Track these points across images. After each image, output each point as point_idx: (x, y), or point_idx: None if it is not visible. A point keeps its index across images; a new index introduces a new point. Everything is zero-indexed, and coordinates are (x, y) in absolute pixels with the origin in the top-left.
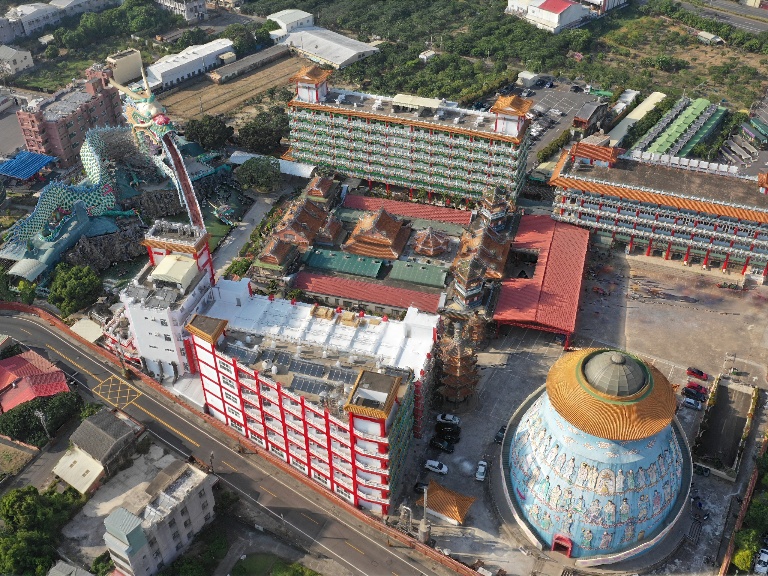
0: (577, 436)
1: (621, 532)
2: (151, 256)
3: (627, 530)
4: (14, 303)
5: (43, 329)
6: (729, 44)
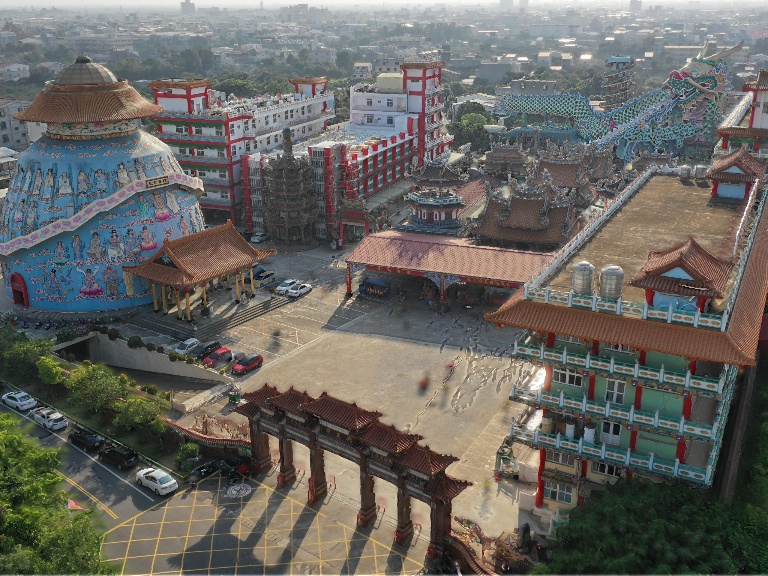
0: None
1: None
2: None
3: None
4: None
5: None
6: None
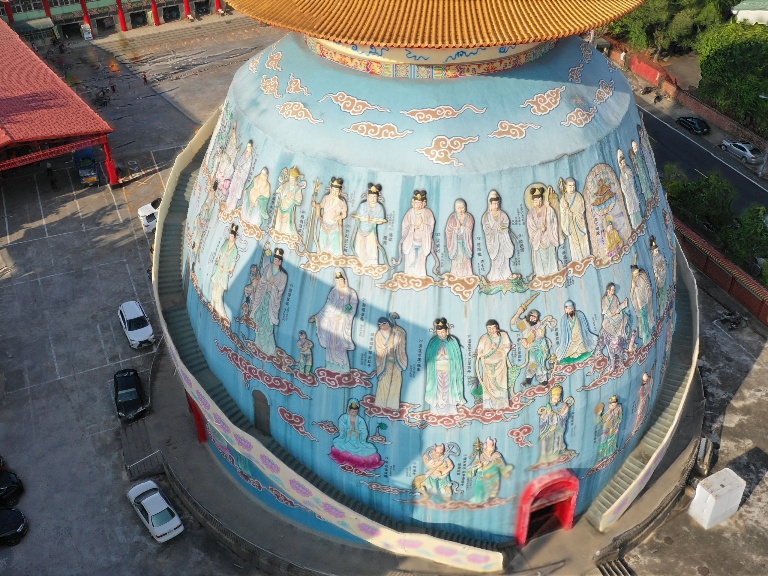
0: (460, 121)
1: (661, 350)
2: None
3: (669, 335)
4: None
5: None
6: None
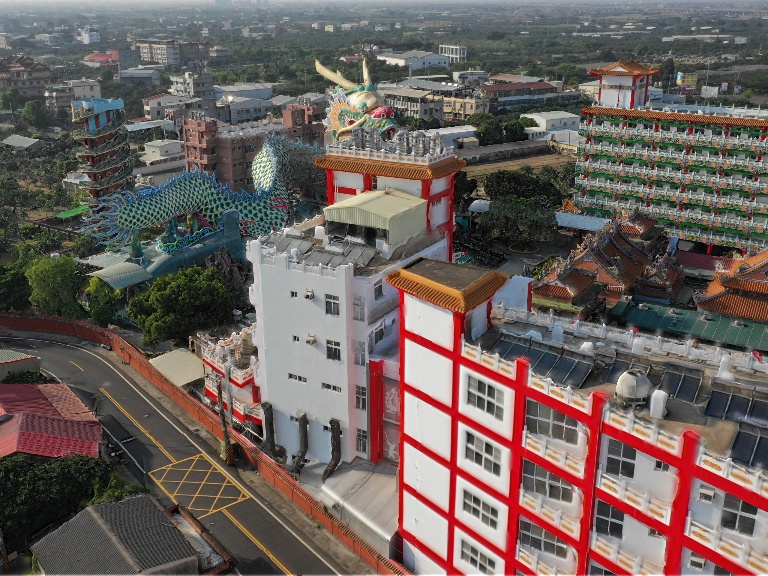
0: None
1: None
2: (330, 199)
3: None
4: (77, 321)
5: (107, 366)
6: None
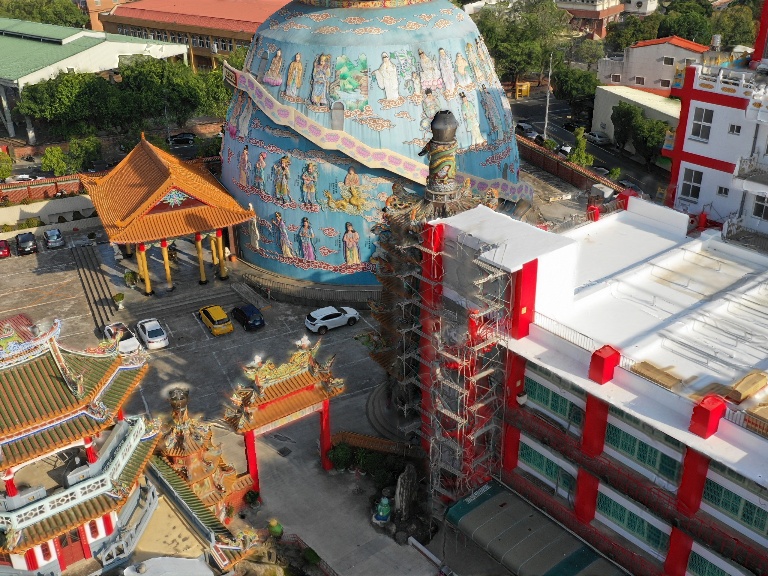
0: None
1: None
2: None
3: None
4: None
5: None
6: None
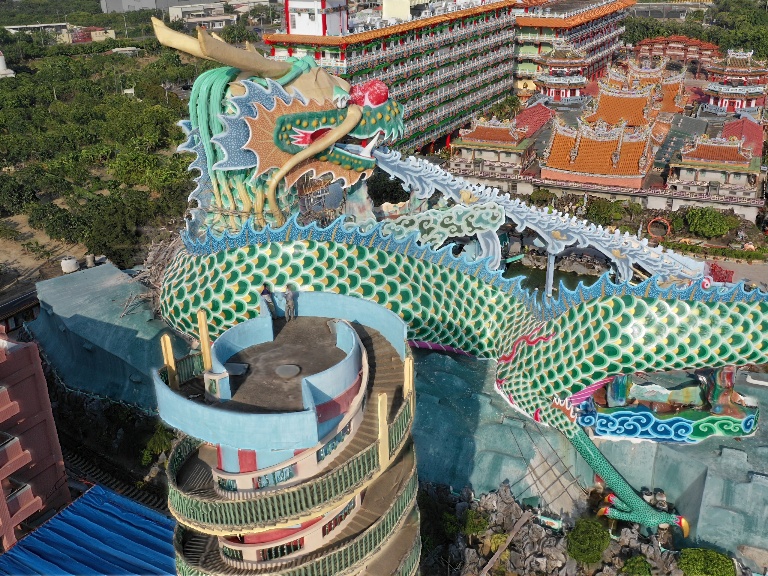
0: None
1: None
2: None
3: None
4: None
5: None
6: (152, 49)
